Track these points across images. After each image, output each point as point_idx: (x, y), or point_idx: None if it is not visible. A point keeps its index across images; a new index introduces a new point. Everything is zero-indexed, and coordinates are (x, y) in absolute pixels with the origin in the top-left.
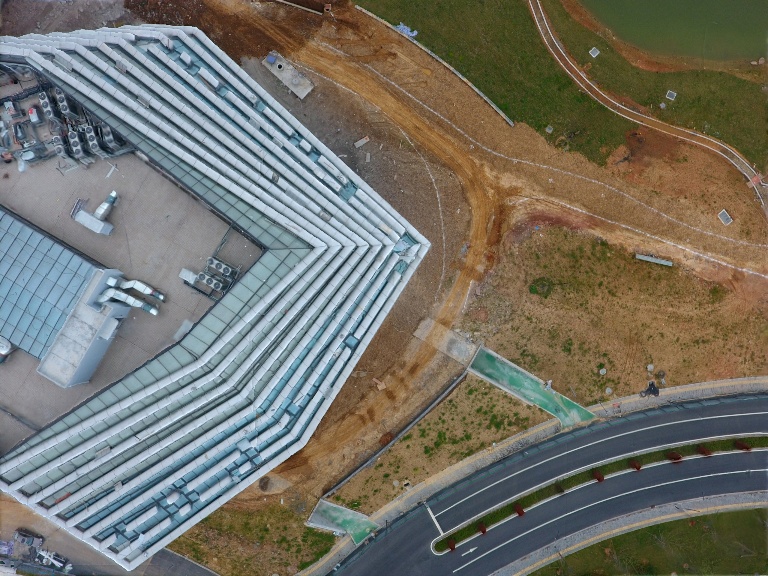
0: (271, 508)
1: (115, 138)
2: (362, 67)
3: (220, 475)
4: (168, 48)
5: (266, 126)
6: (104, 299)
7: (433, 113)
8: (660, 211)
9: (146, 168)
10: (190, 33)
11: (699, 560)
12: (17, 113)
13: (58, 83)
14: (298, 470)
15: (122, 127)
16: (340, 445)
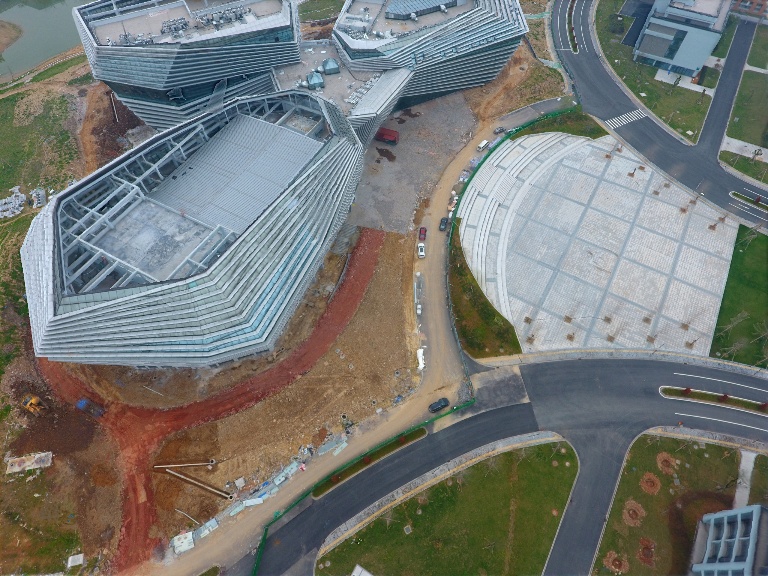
0: (533, 70)
1: None
2: None
3: (512, 3)
4: None
5: None
6: None
7: None
8: None
9: None
10: None
11: None
12: None
13: None
14: (523, 61)
15: None
16: (520, 49)
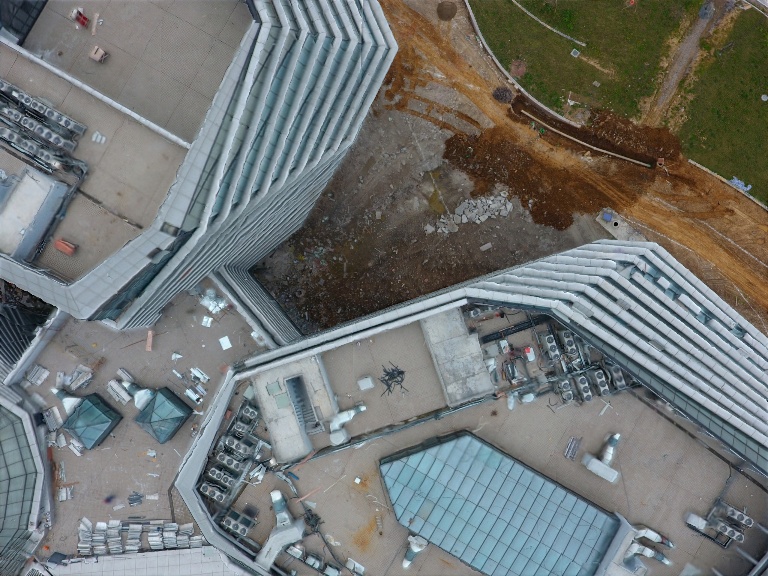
0: None
1: (626, 383)
2: (697, 223)
3: None
4: (644, 272)
5: (756, 357)
6: (627, 555)
7: (767, 269)
8: None
9: (640, 405)
10: (650, 249)
11: None
12: (508, 350)
13: (587, 336)
14: None
15: (653, 381)
16: None
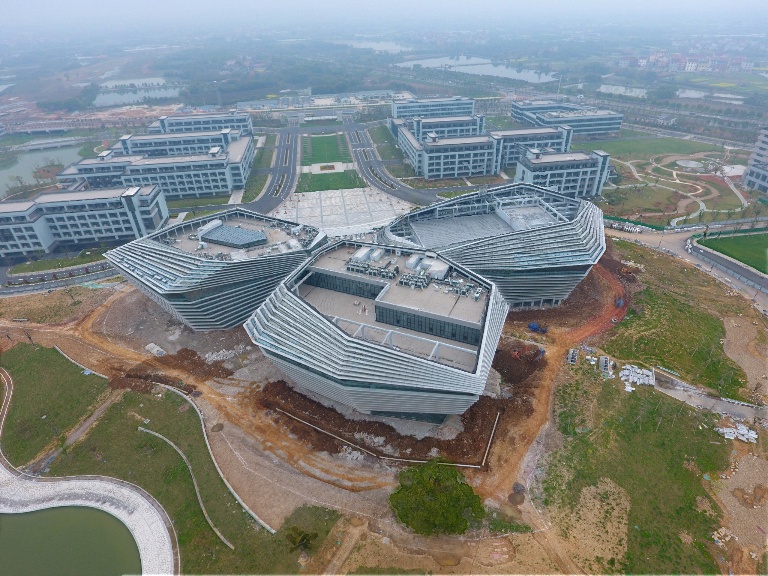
0: None
1: None
2: None
3: None
4: None
5: None
6: None
7: None
8: (5, 332)
9: None
10: None
11: (64, 260)
12: None
13: None
14: None
15: None
16: None
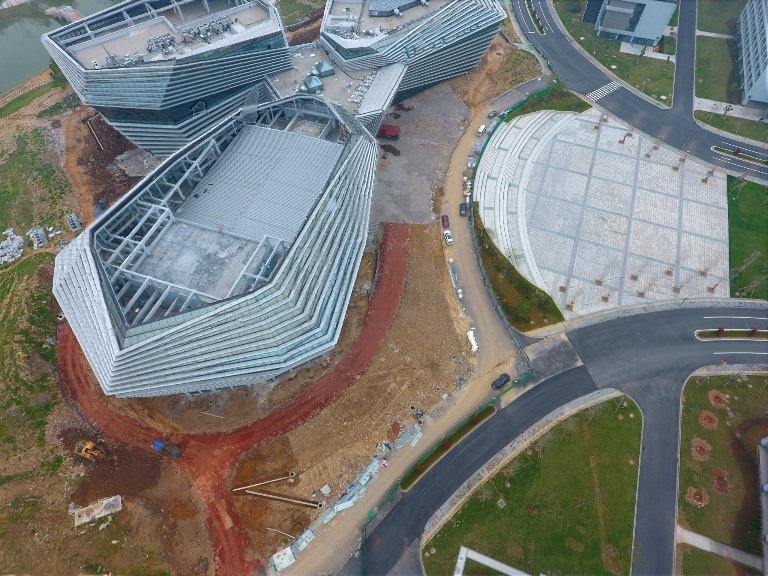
0: None
1: None
2: None
3: None
4: None
5: None
6: None
7: None
8: None
9: None
10: None
11: None
12: None
13: None
14: None
15: None
16: None
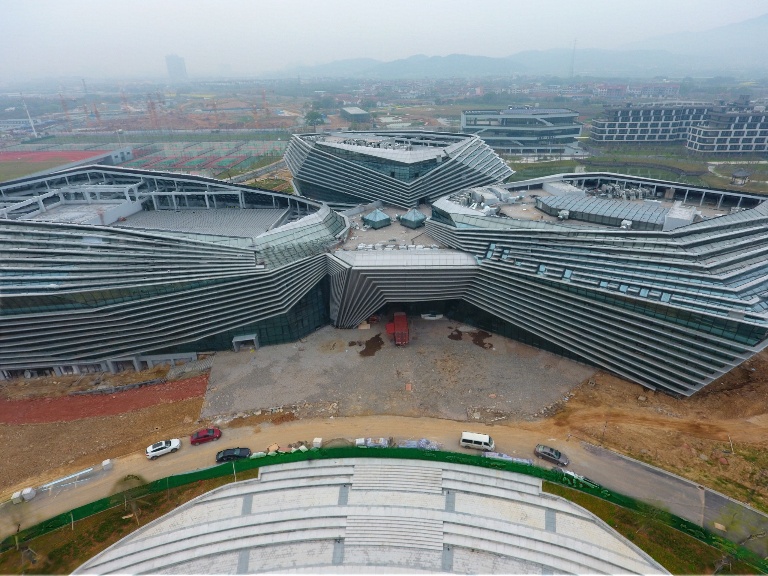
0: None
1: (649, 190)
2: None
3: None
4: None
5: None
6: None
7: None
8: None
9: None
10: None
11: None
12: (587, 192)
13: None
14: None
15: None
16: None
